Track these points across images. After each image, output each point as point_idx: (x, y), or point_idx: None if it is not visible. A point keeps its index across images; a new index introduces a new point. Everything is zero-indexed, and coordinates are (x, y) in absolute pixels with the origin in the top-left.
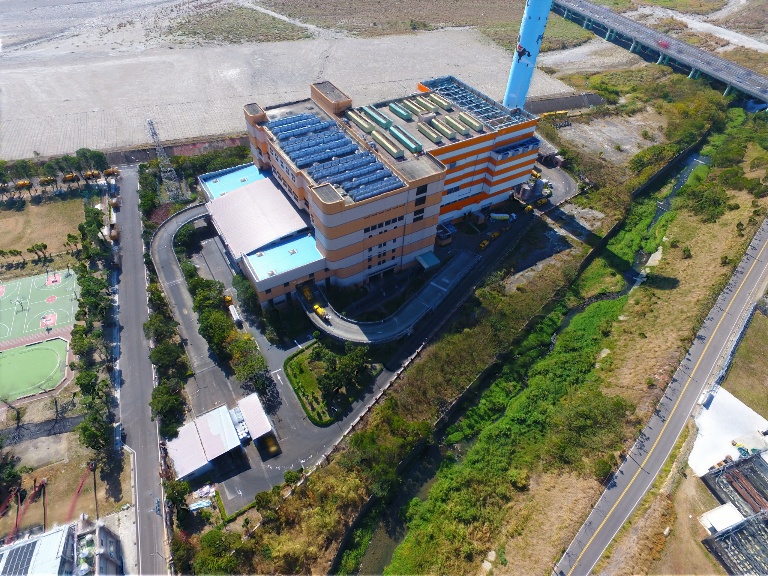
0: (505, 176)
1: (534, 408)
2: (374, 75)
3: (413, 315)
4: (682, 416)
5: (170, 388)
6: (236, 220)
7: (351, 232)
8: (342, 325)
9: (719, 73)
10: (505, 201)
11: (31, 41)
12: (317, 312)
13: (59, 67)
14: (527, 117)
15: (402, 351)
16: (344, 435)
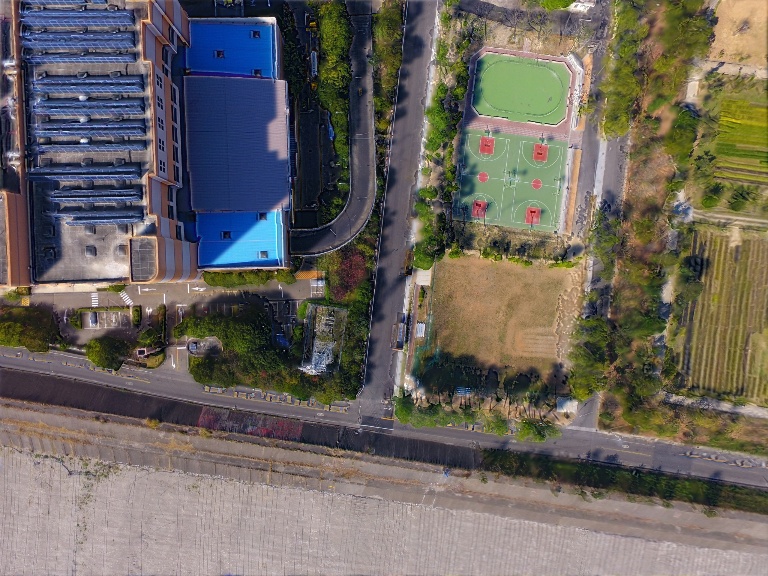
0: None
1: None
2: None
3: None
4: None
5: None
6: (263, 146)
7: None
8: None
9: None
10: None
11: None
12: None
13: None
14: None
15: None
16: None
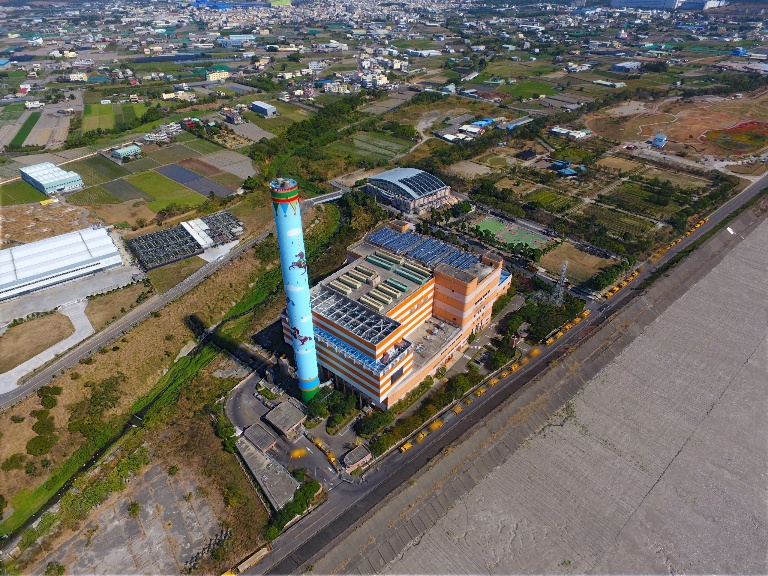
0: None
1: None
2: None
3: None
4: None
5: None
6: None
7: None
8: None
9: None
10: None
11: None
12: None
13: None
14: None
15: None
16: None
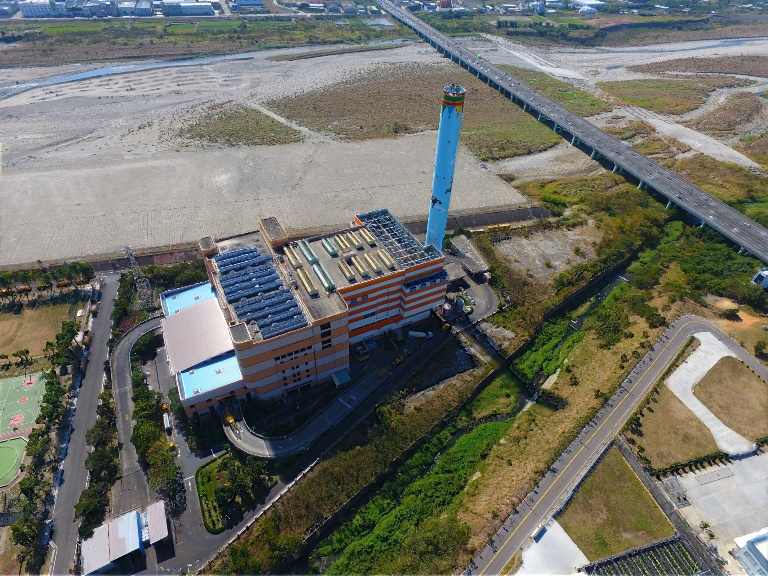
0: (418, 303)
1: (398, 527)
2: (346, 182)
3: (314, 431)
4: (512, 548)
5: (96, 491)
6: (180, 338)
7: (262, 361)
8: (250, 439)
9: (662, 188)
10: (426, 319)
11: (63, 142)
12: (231, 426)
13: (79, 170)
14: (438, 254)
15: (299, 465)
16: (229, 543)
